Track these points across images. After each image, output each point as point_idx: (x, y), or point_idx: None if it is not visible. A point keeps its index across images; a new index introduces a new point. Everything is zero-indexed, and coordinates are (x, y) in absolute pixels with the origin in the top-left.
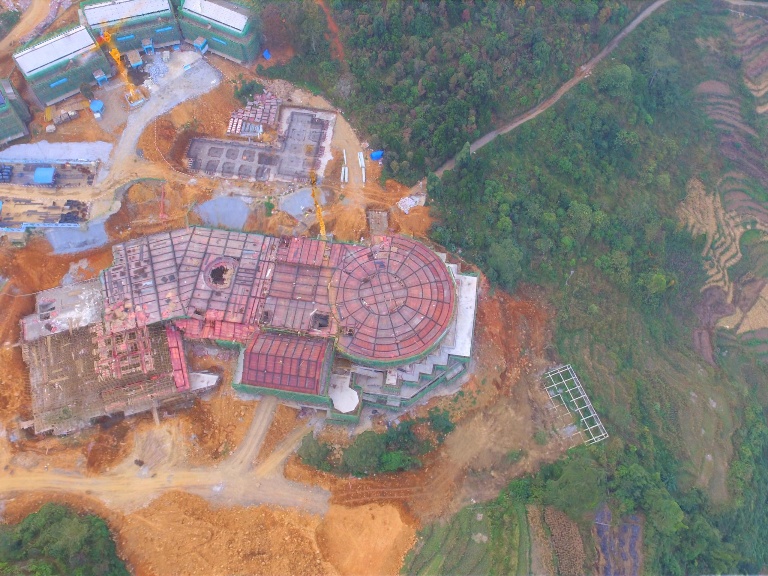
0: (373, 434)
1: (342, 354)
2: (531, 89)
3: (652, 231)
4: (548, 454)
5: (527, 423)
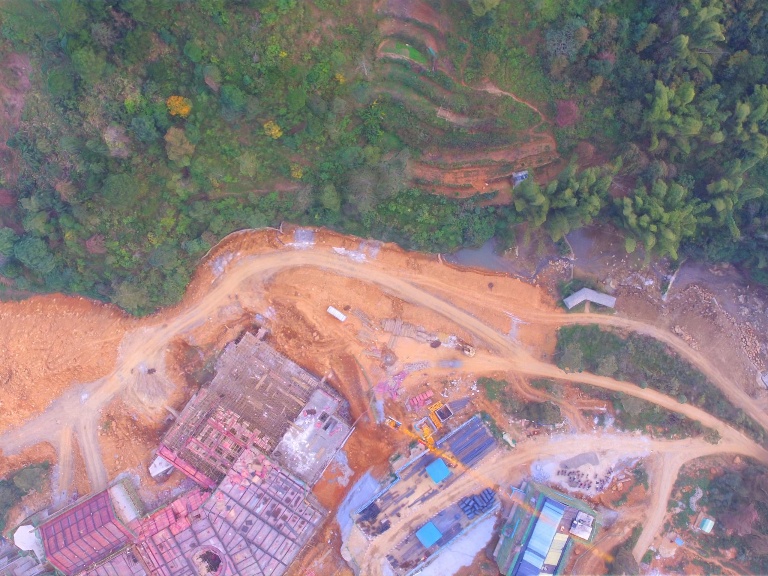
0: None
1: (49, 574)
2: None
3: None
4: None
5: None
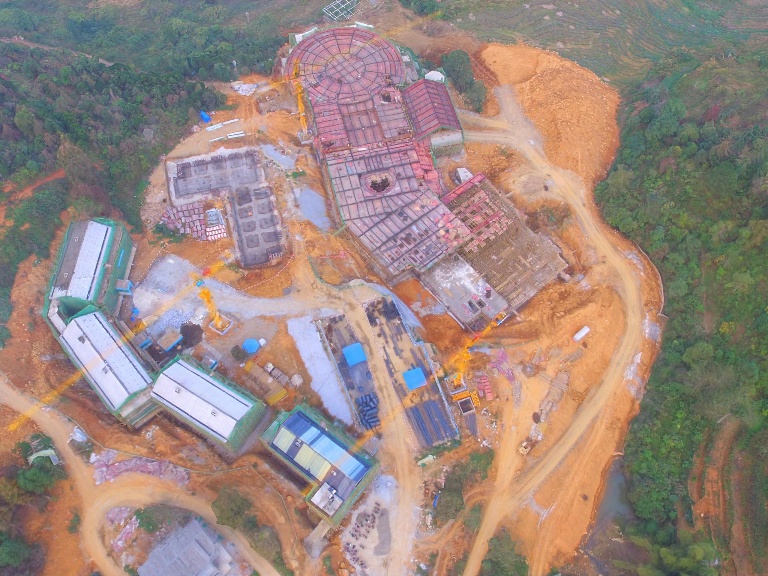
0: (451, 56)
1: None
2: (65, 55)
3: (169, 4)
4: (397, 4)
5: (382, 16)
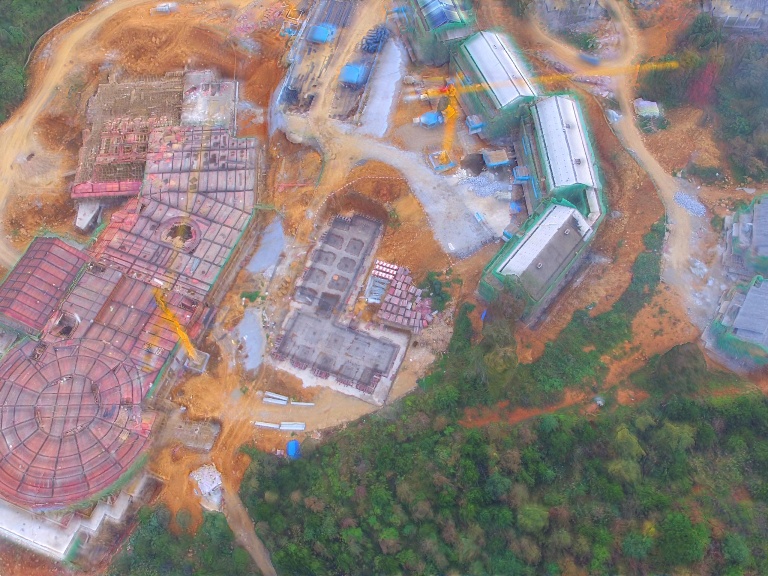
0: None
1: None
2: None
3: None
4: None
5: None
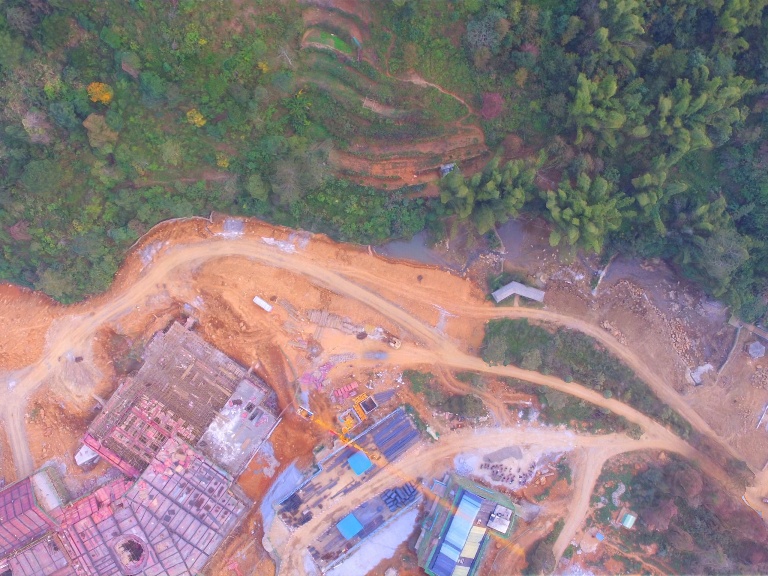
0: None
1: None
2: None
3: None
4: None
5: None
